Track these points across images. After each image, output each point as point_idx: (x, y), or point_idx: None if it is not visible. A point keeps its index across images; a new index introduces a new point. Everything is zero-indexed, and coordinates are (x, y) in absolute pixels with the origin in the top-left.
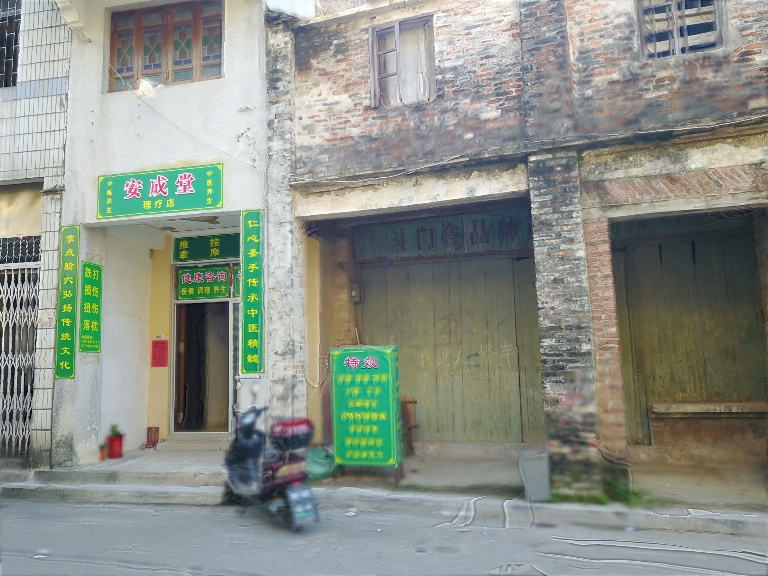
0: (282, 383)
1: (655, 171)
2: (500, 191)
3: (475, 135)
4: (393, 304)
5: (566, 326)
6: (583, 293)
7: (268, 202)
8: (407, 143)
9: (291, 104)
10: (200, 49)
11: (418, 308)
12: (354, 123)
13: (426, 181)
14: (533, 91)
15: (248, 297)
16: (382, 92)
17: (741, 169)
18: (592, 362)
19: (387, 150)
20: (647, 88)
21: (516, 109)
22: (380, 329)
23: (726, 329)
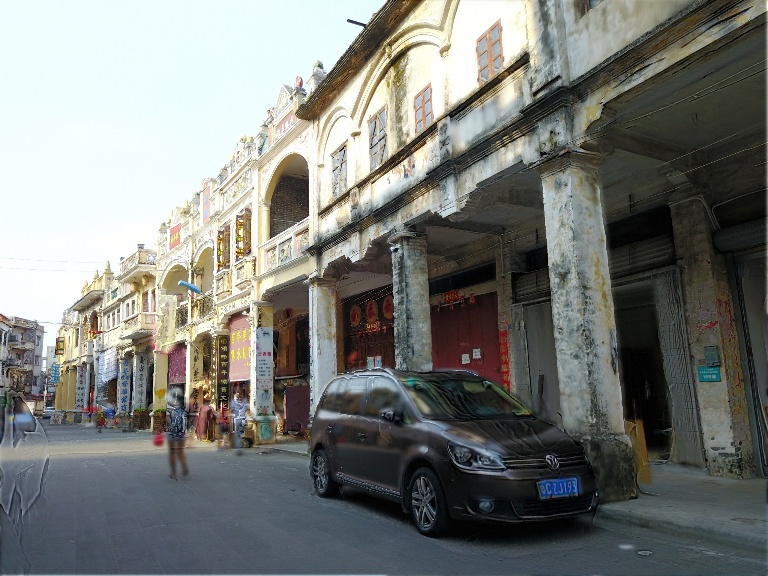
0: None
1: None
2: None
3: None
4: None
5: None
6: None
7: None
8: None
9: None
10: None
11: None
12: None
13: None
14: None
15: None
16: None
17: None
18: None
19: None
20: None
21: None
22: None
23: None
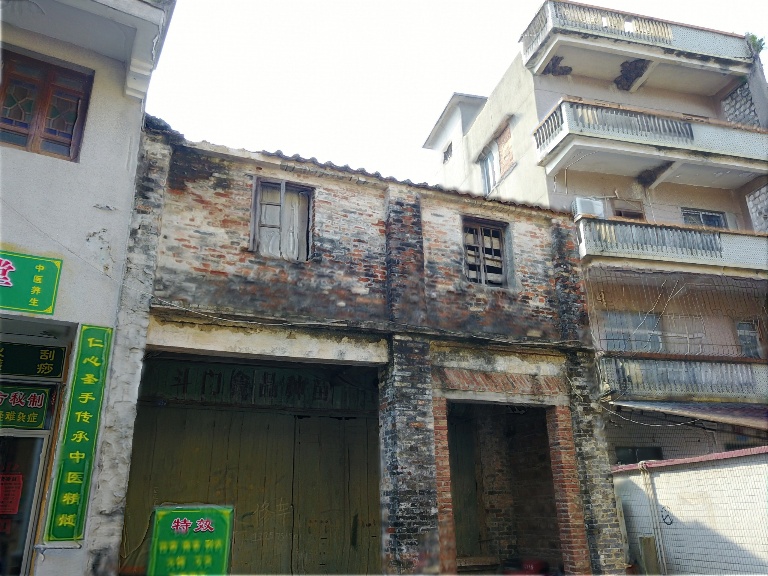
0: (106, 553)
1: (476, 367)
2: (366, 360)
3: (347, 304)
4: (162, 451)
5: (420, 491)
6: (432, 461)
7: (118, 320)
8: (284, 295)
9: (159, 219)
10: (43, 118)
11: (192, 458)
12: (229, 260)
13: (300, 336)
14: (399, 282)
15: (74, 435)
16: (260, 239)
17: (525, 377)
18: (437, 525)
19: (263, 296)
20: (471, 303)
21: (381, 292)
22: (140, 480)
23: (456, 494)
